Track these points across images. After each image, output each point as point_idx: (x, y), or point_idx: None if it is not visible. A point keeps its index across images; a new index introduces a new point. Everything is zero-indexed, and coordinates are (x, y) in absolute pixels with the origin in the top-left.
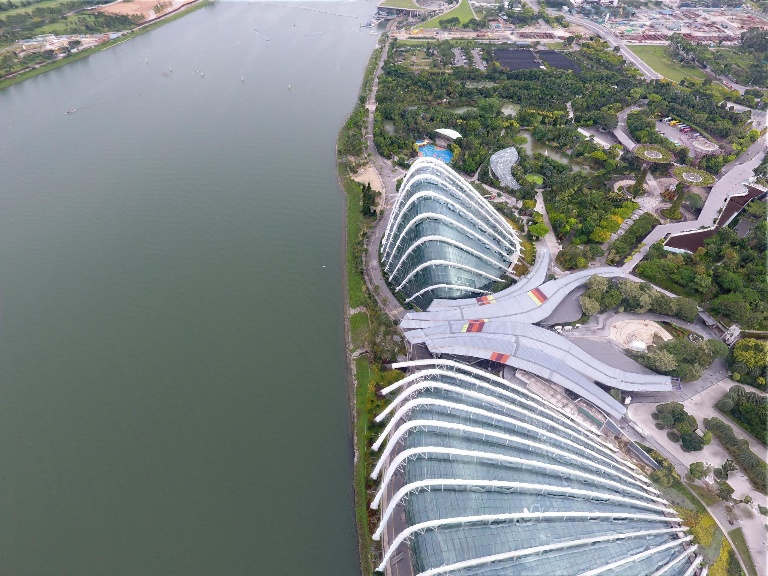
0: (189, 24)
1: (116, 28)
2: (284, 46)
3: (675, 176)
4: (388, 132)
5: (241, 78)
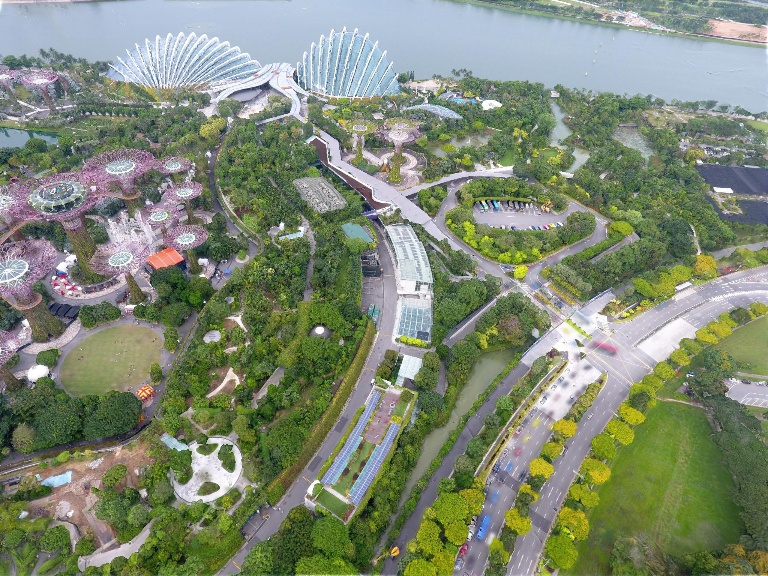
0: (730, 50)
1: (672, 26)
2: (697, 78)
3: (363, 122)
4: (488, 85)
5: (594, 61)
